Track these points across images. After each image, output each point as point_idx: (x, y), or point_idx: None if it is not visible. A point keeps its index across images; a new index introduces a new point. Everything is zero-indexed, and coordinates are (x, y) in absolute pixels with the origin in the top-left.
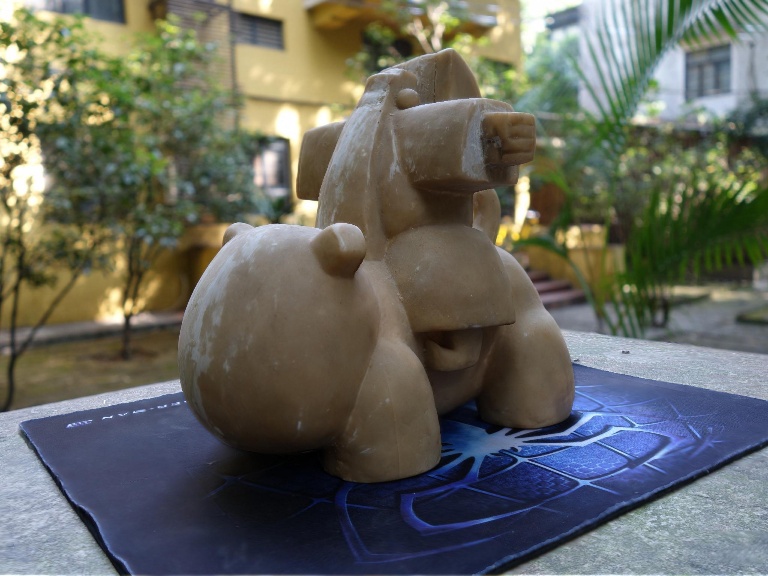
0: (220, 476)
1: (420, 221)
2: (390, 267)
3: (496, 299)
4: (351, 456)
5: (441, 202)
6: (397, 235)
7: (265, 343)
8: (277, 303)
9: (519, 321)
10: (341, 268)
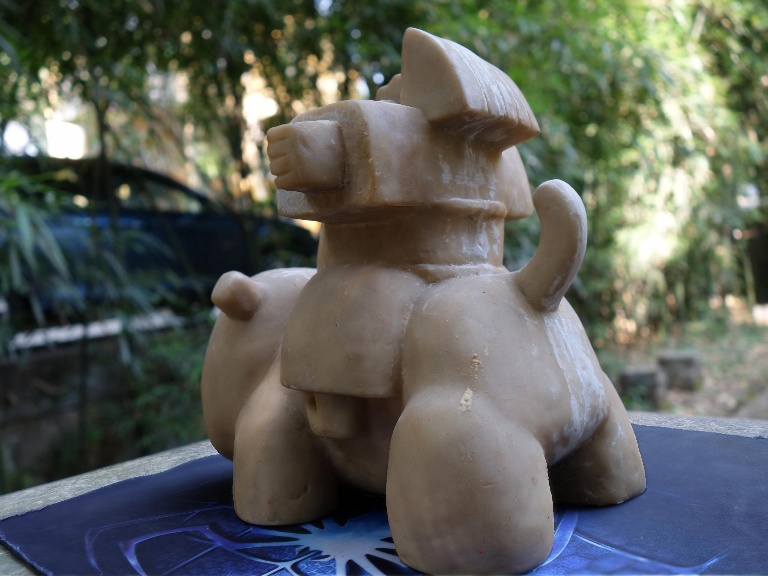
0: None
1: (328, 261)
2: None
3: (315, 359)
4: None
5: (341, 237)
6: None
7: None
8: None
9: (411, 398)
10: None
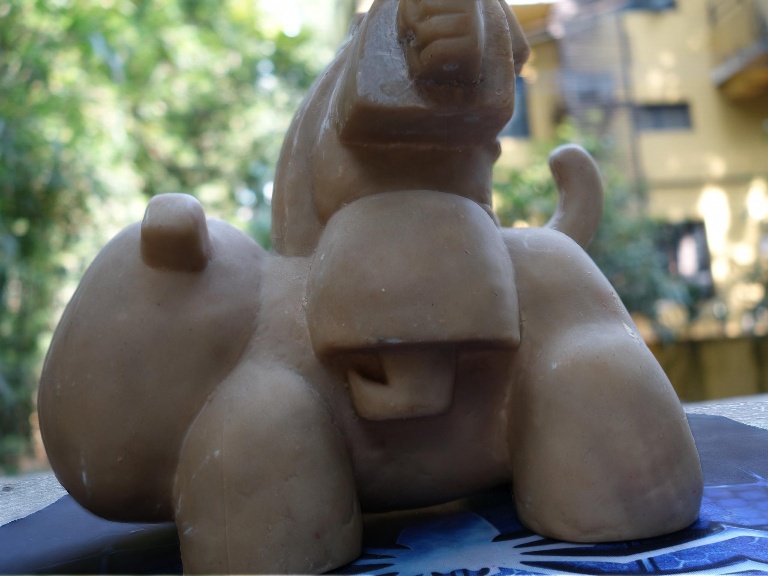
0: (106, 547)
1: (354, 192)
2: None
3: (441, 296)
4: (180, 537)
5: (389, 160)
6: (329, 218)
7: (56, 360)
8: (78, 307)
9: (551, 343)
10: (157, 254)
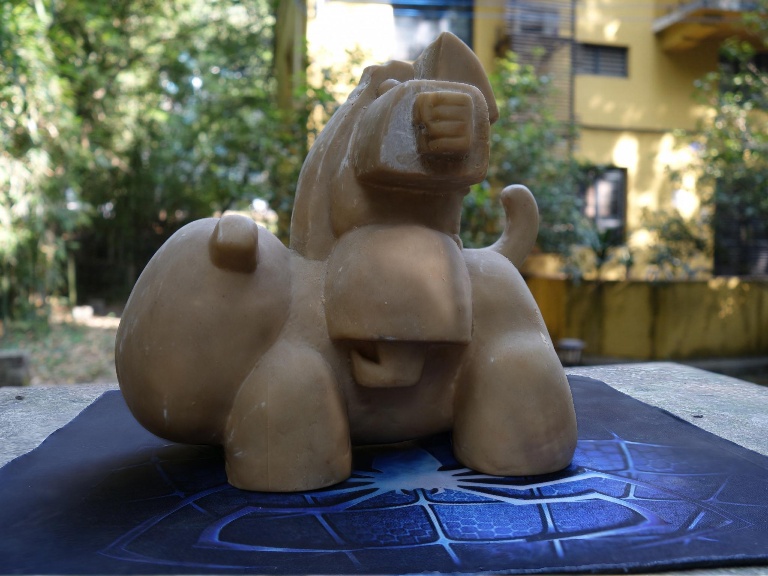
0: (152, 457)
1: (364, 219)
2: (327, 268)
3: (424, 310)
4: (230, 457)
5: (392, 199)
6: (342, 234)
7: (143, 328)
8: (160, 290)
9: (491, 343)
10: (225, 260)
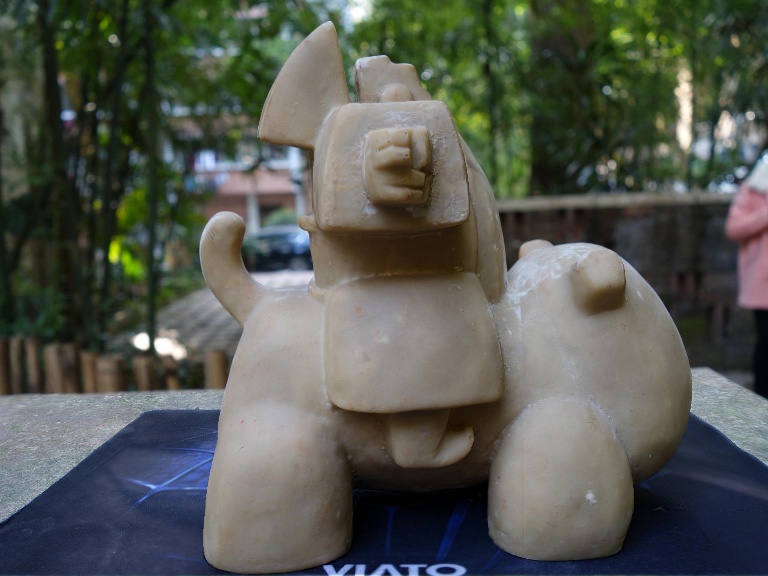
0: (652, 489)
1: None
2: None
3: None
4: None
5: None
6: None
7: None
8: None
9: None
10: None
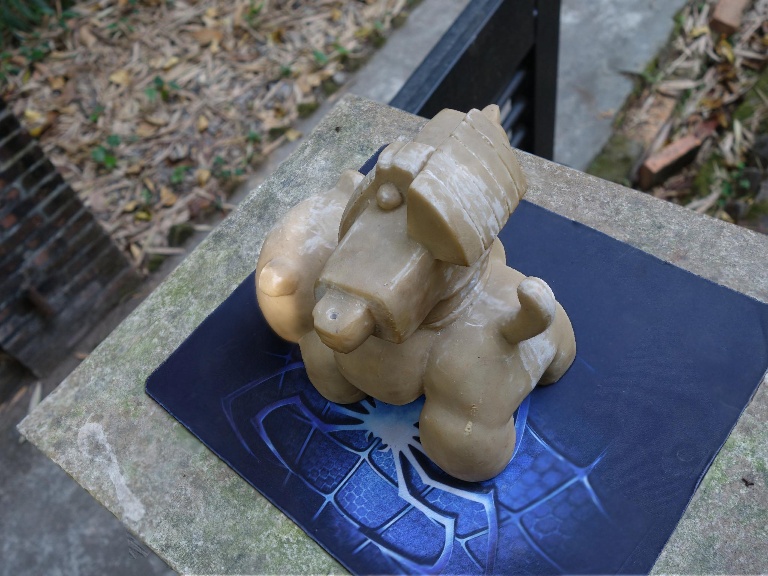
0: None
1: None
2: None
3: (365, 384)
4: None
5: None
6: None
7: None
8: None
9: (432, 406)
10: None
